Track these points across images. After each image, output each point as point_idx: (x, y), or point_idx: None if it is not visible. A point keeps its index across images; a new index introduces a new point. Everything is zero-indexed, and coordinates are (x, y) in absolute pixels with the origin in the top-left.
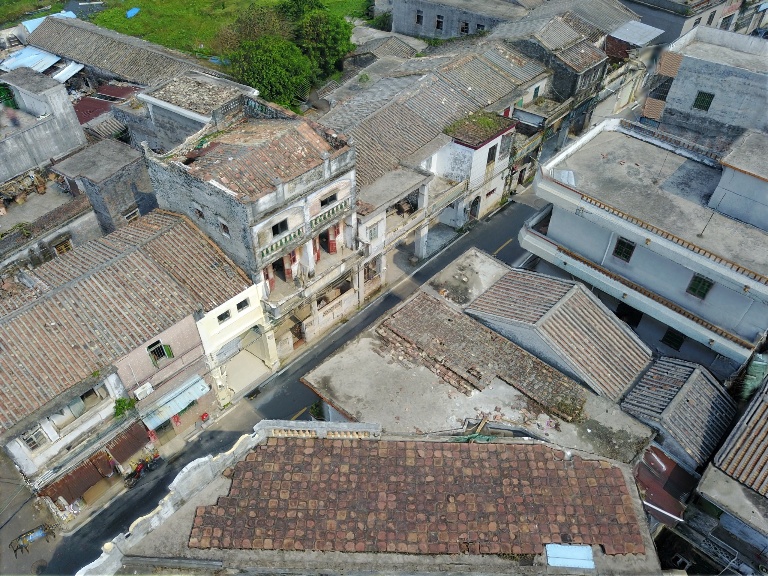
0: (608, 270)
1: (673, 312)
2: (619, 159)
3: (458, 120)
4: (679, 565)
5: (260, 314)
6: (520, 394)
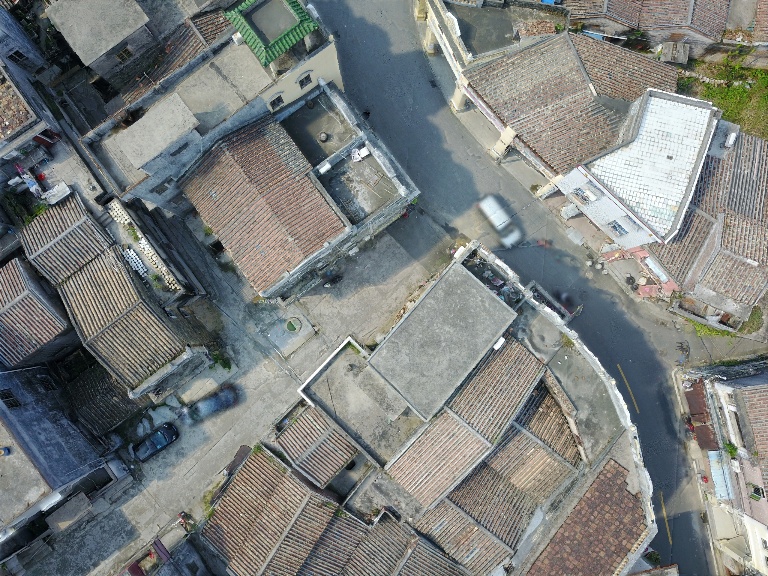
0: None
1: None
2: None
3: None
4: None
5: (758, 567)
6: None
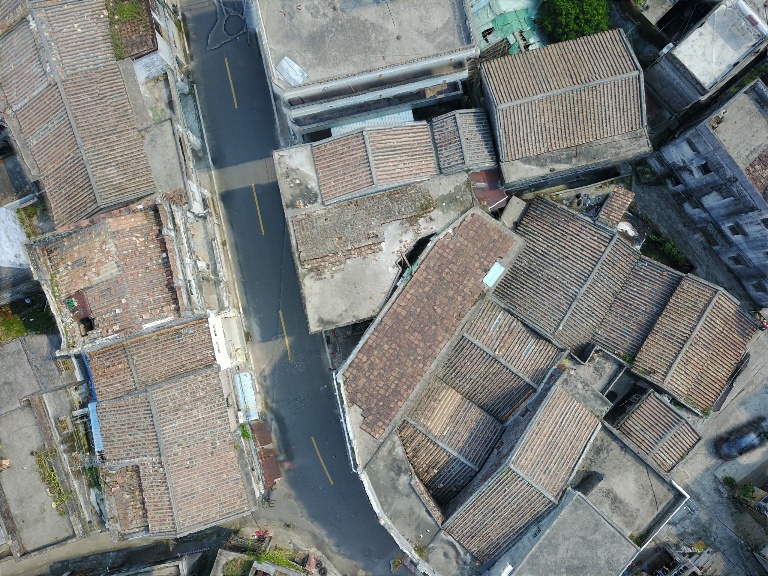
0: (361, 92)
1: (414, 83)
2: (294, 5)
3: (109, 33)
4: (510, 196)
5: (218, 318)
6: (400, 221)
